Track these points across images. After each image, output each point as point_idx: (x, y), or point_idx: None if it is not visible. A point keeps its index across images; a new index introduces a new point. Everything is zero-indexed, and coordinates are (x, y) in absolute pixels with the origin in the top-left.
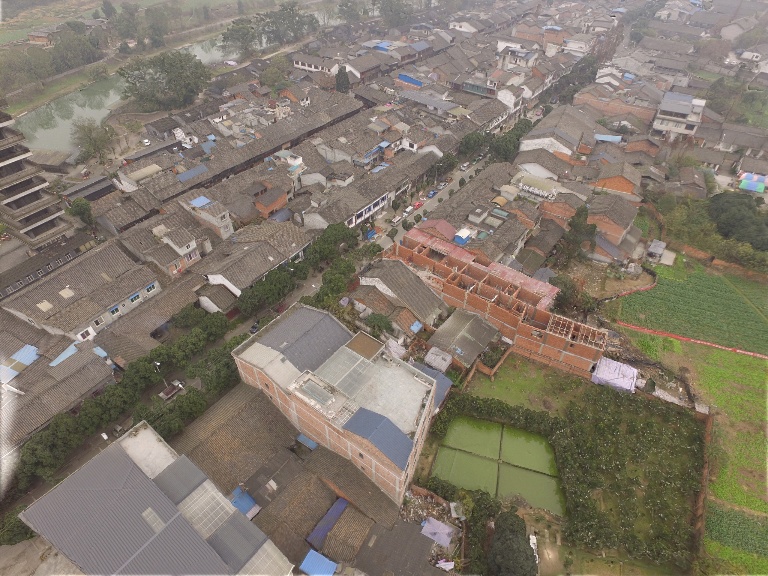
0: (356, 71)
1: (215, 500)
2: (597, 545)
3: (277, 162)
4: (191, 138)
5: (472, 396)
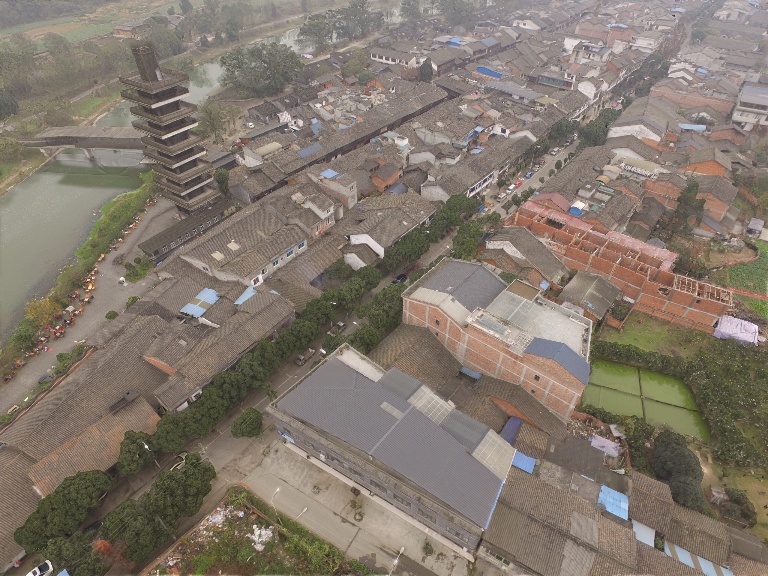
0: (434, 64)
1: (434, 400)
2: (748, 463)
3: (384, 143)
4: (296, 121)
5: (610, 342)
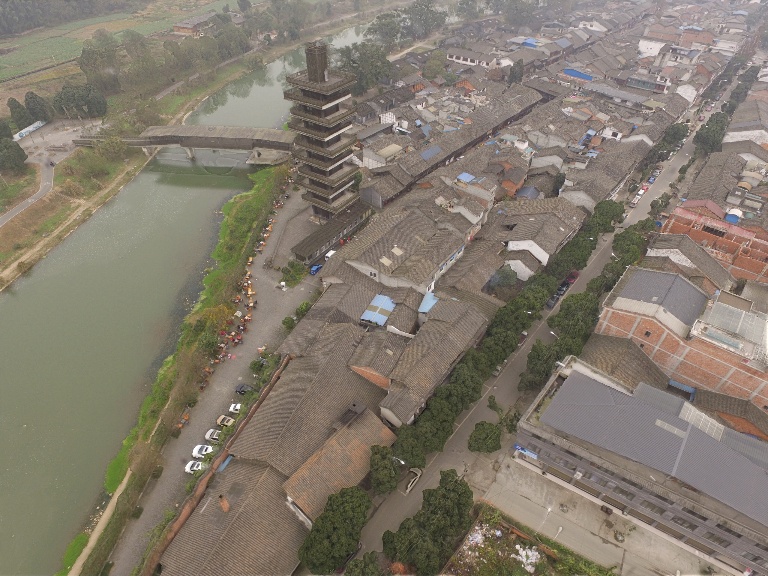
0: None
1: (703, 418)
2: None
3: (502, 145)
4: (399, 122)
5: None
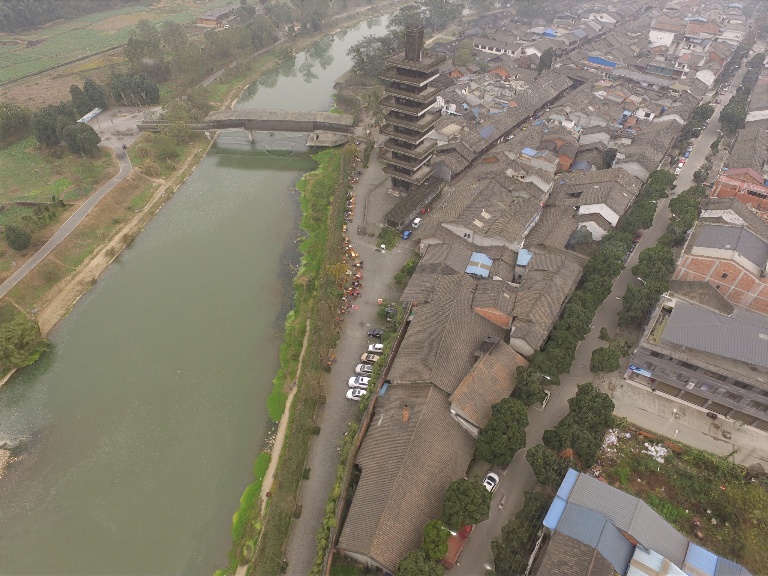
0: None
1: None
2: None
3: (550, 125)
4: (447, 106)
5: None
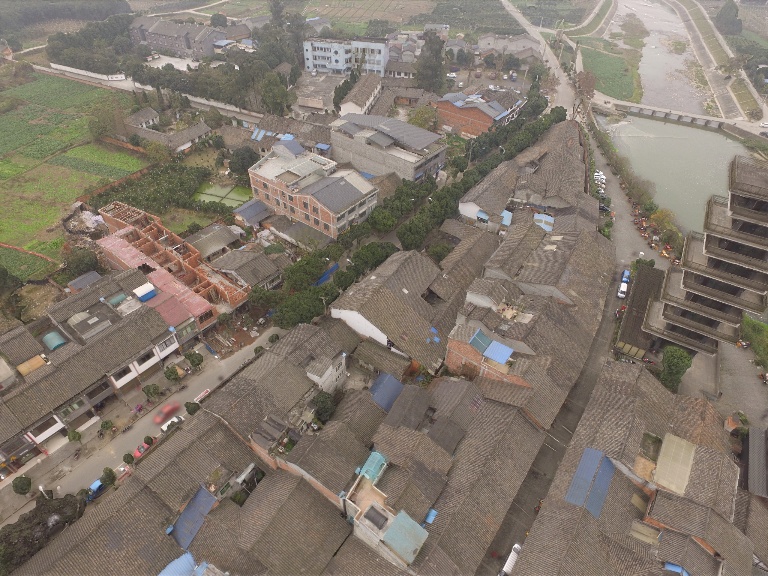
0: None
1: None
2: None
3: None
4: None
5: (223, 209)
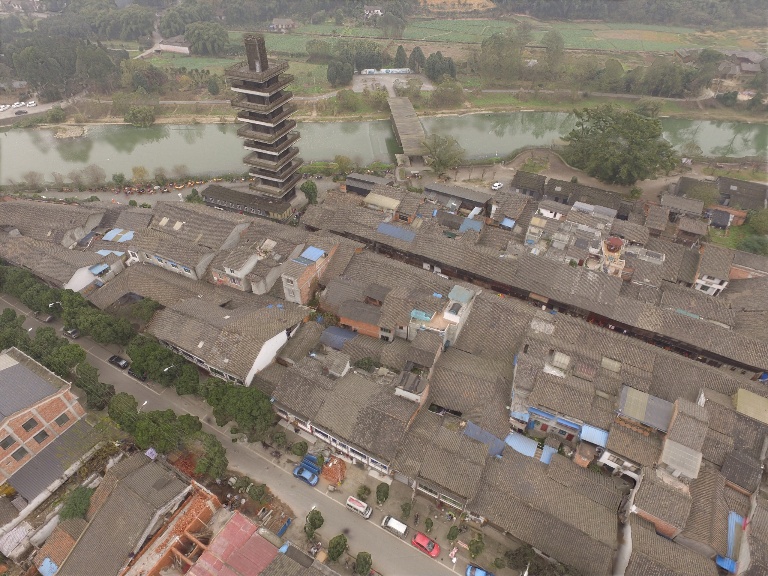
0: None
1: None
2: None
3: None
4: None
5: None
